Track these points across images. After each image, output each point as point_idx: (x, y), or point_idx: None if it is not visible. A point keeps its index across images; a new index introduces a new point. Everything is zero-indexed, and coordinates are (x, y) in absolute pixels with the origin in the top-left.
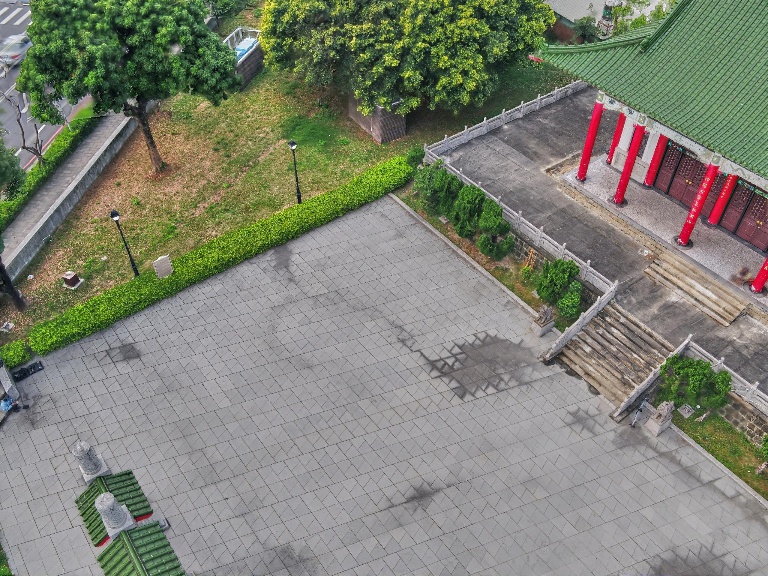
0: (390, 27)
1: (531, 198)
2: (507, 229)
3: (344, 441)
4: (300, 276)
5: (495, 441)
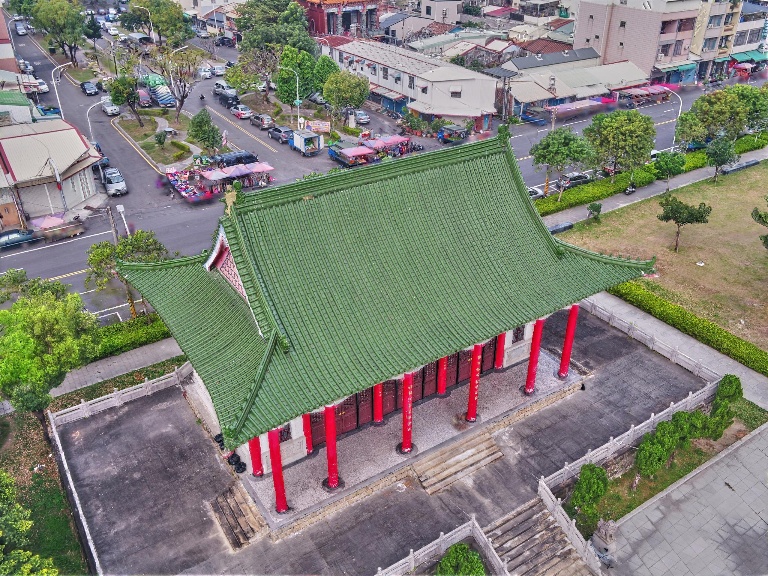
0: None
1: None
2: None
3: None
4: None
5: None
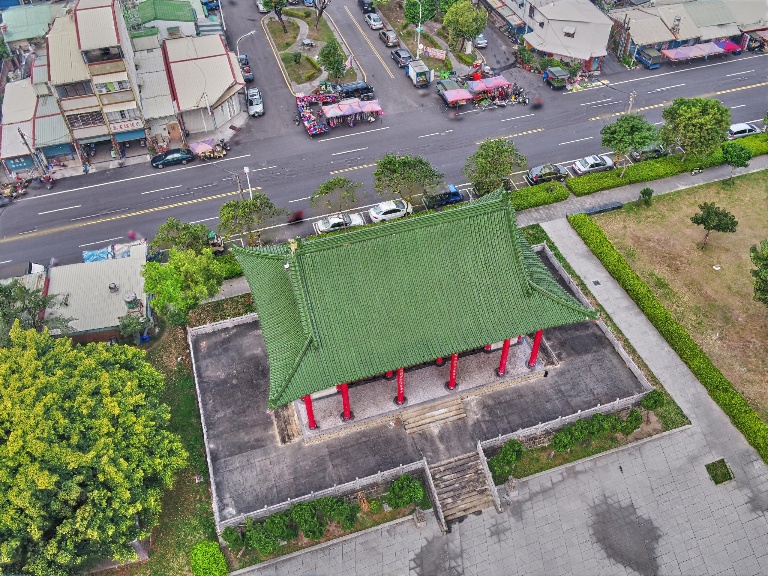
0: (103, 491)
1: (308, 468)
2: None
3: None
4: None
5: None
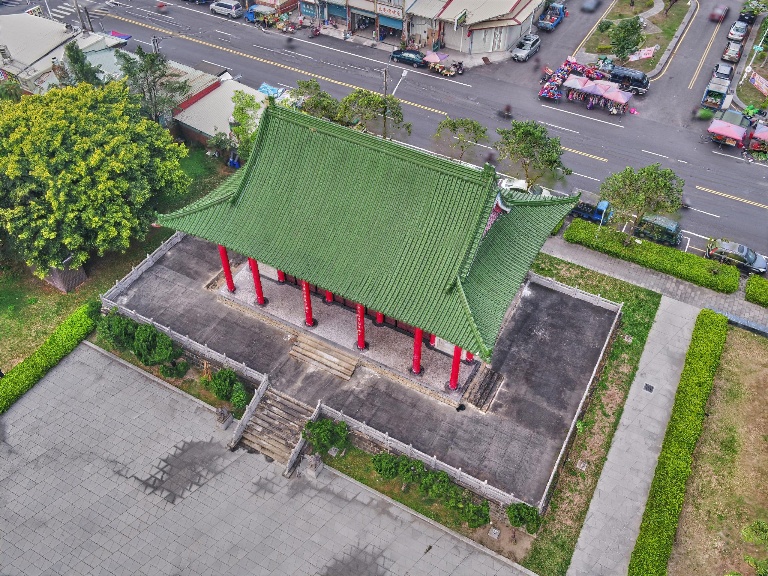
0: (38, 206)
1: (198, 316)
2: (180, 353)
3: (85, 575)
4: (18, 445)
5: (203, 527)
